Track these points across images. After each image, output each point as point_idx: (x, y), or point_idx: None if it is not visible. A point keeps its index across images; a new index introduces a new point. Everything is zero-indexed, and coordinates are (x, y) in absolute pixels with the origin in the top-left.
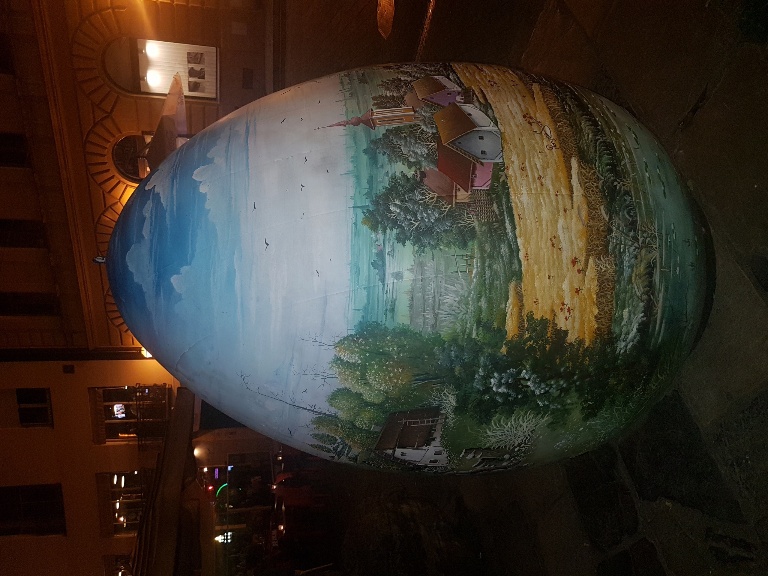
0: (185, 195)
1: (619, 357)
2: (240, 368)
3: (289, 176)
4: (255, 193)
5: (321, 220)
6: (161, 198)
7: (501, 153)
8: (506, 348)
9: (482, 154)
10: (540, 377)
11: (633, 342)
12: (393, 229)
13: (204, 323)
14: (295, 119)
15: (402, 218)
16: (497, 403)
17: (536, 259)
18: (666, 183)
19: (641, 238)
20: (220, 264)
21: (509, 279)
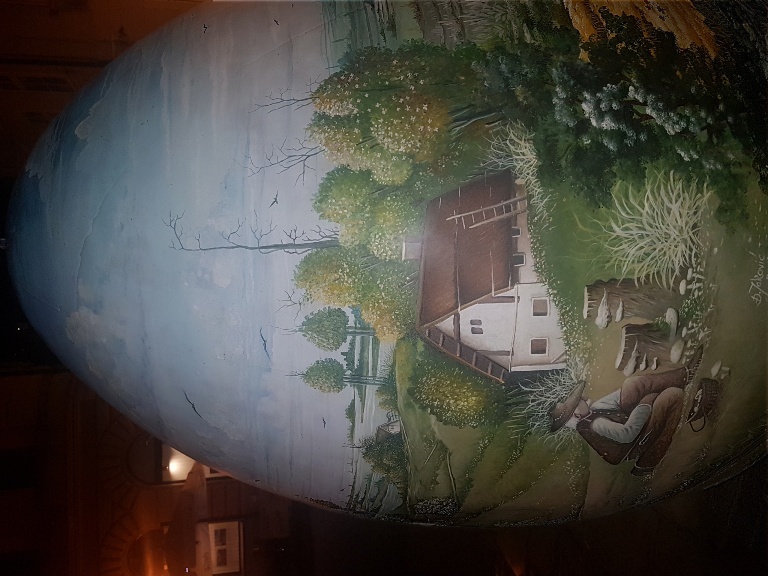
0: None
1: None
2: (168, 207)
3: None
4: (194, 11)
5: None
6: None
7: None
8: (586, 53)
9: None
10: (662, 100)
11: None
12: None
13: (115, 158)
14: None
15: None
16: (608, 153)
17: None
18: None
19: None
20: (142, 74)
21: None
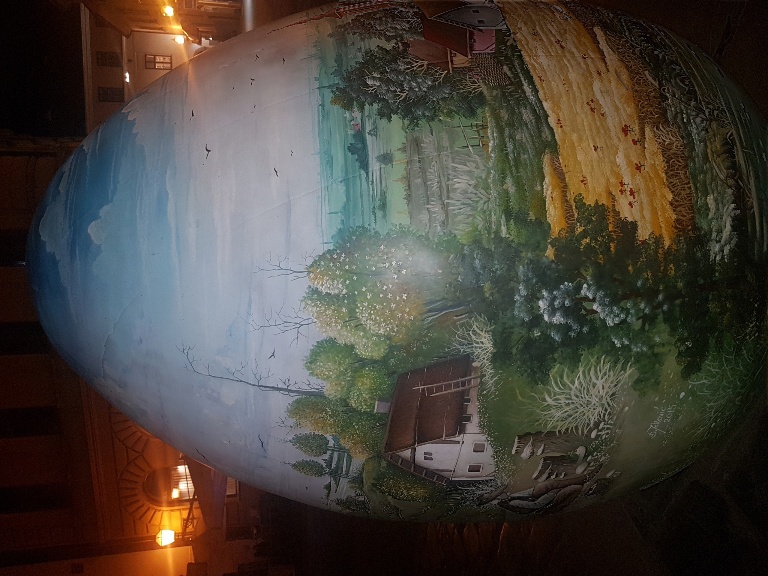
0: (111, 130)
1: (715, 267)
2: (181, 337)
3: (236, 75)
4: (194, 101)
5: (277, 109)
6: (84, 145)
7: (503, 21)
8: (553, 250)
9: (479, 23)
10: (609, 296)
11: (730, 245)
12: (373, 104)
13: (130, 278)
14: (246, 35)
15: (384, 91)
16: (553, 343)
17: (573, 126)
18: (718, 66)
19: (706, 109)
20: (148, 190)
21: (540, 152)
